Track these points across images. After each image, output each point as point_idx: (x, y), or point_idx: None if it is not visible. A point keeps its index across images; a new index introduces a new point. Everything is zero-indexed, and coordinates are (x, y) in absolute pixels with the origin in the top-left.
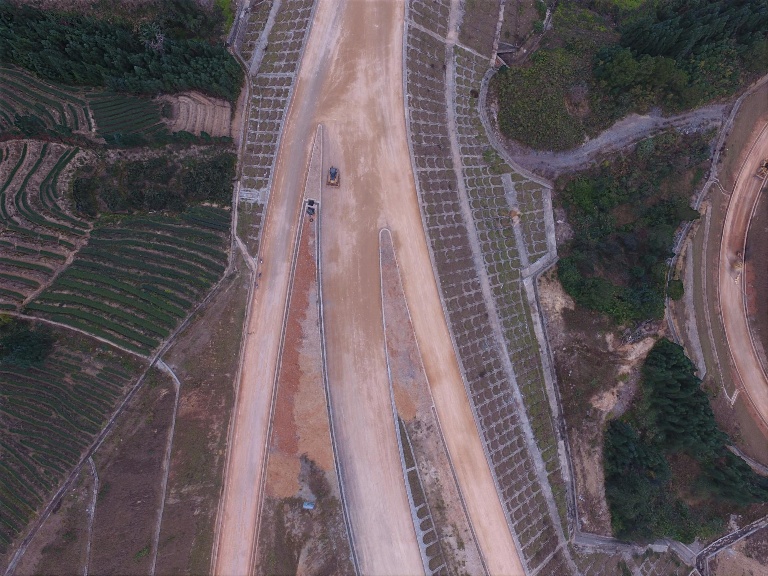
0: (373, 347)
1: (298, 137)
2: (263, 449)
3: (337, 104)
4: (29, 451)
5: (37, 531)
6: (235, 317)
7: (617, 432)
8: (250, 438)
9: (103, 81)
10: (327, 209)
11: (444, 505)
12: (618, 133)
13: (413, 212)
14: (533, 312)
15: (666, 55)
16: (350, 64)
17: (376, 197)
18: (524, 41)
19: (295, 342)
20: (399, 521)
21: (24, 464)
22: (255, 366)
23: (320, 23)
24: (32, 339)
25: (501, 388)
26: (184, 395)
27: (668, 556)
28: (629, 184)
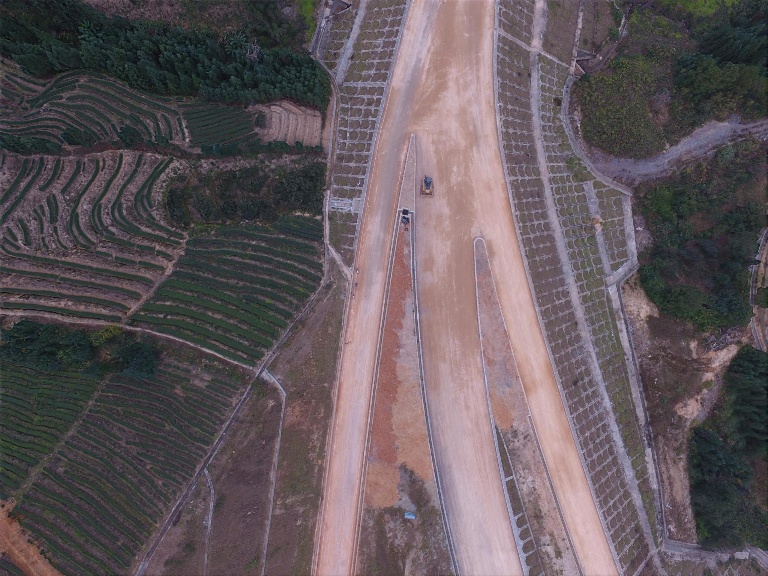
0: (469, 356)
1: (391, 146)
2: (361, 459)
3: (429, 113)
4: (146, 463)
5: (159, 544)
6: (332, 327)
7: (703, 439)
8: (348, 448)
9: (195, 91)
10: (421, 218)
11: (541, 514)
12: (698, 140)
13: (506, 221)
14: (618, 320)
15: (746, 62)
16: (441, 73)
17: (469, 206)
18: (600, 48)
19: (392, 352)
20: (498, 530)
21: (142, 477)
22: (352, 376)
23: (411, 32)
24: (144, 351)
25: (592, 396)
26: (289, 406)
27: (749, 563)
28: (710, 191)
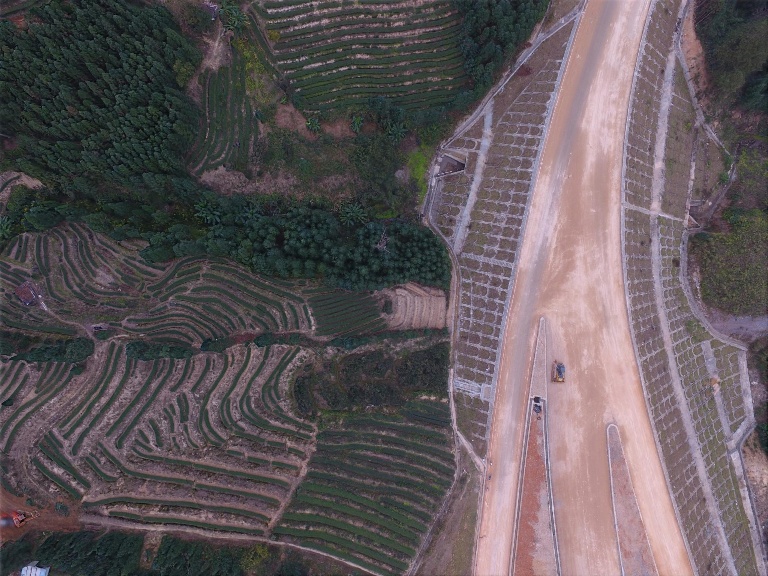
0: (605, 548)
1: (520, 331)
2: None
3: (558, 295)
4: None
5: None
6: (468, 522)
7: None
8: None
9: (318, 274)
10: (553, 405)
11: None
12: None
13: (639, 405)
14: (741, 487)
15: None
16: (569, 252)
17: (601, 391)
18: (710, 194)
19: (528, 546)
20: None
21: None
22: (487, 570)
23: (537, 210)
24: None
25: (723, 575)
26: None
27: None
28: None
